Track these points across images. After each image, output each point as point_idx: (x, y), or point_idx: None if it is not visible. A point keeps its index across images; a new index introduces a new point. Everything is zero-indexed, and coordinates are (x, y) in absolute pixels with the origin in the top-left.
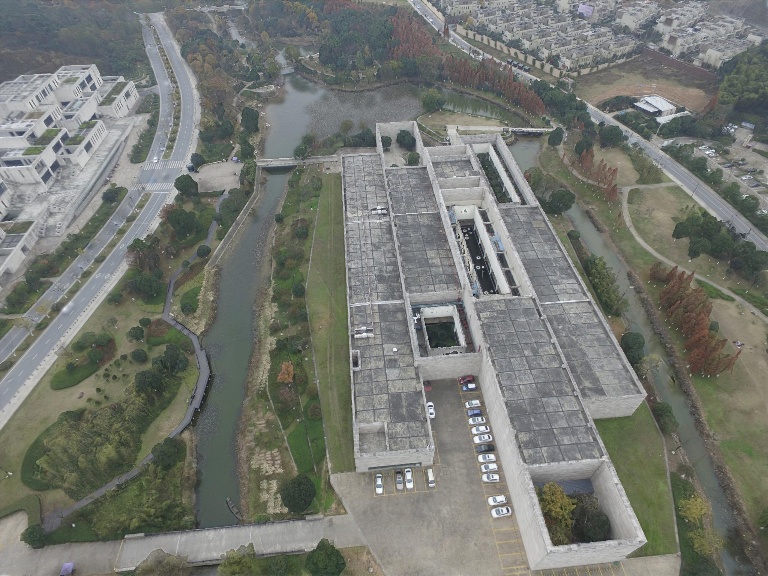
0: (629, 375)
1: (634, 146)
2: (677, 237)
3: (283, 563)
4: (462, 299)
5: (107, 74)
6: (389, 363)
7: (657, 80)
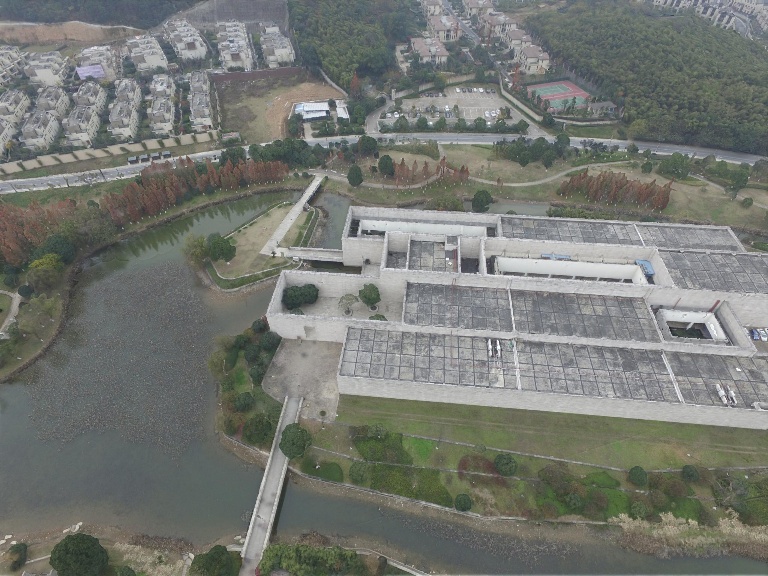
0: None
1: (380, 142)
2: None
3: None
4: None
5: None
6: (759, 378)
7: (270, 94)
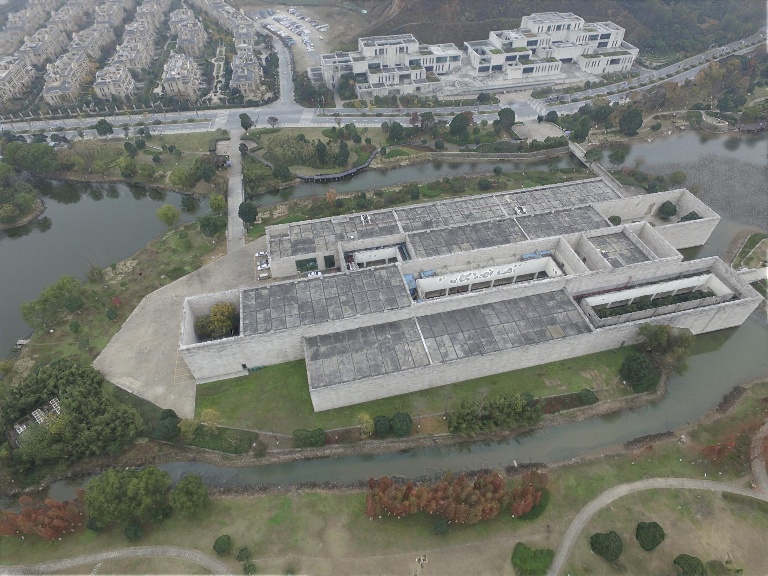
0: None
1: None
2: None
3: (218, 220)
4: None
5: (637, 44)
6: (339, 235)
7: None
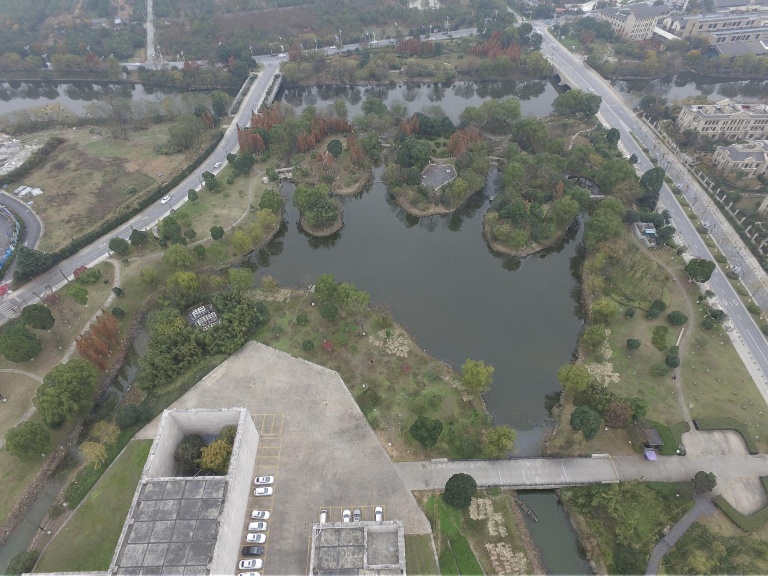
0: None
1: None
2: None
3: (464, 444)
4: None
5: None
6: None
7: None
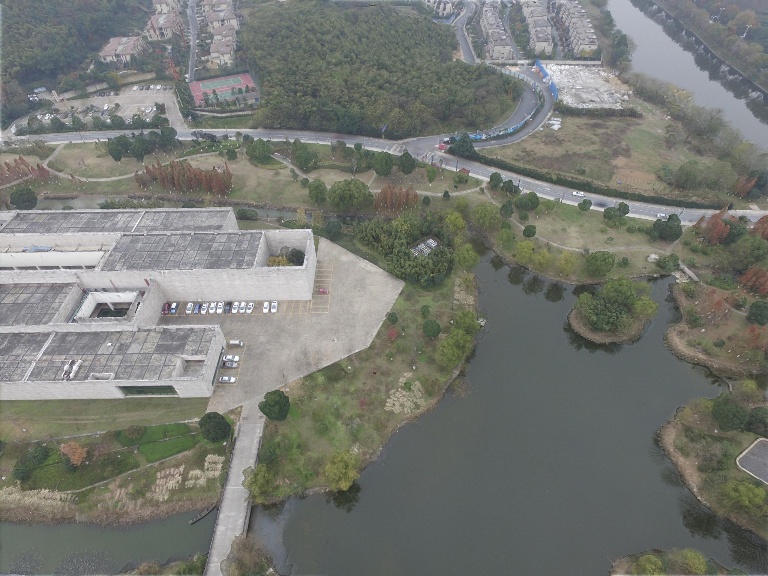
0: (215, 212)
1: None
2: (119, 159)
3: (266, 447)
4: (85, 288)
5: None
6: (121, 350)
7: None
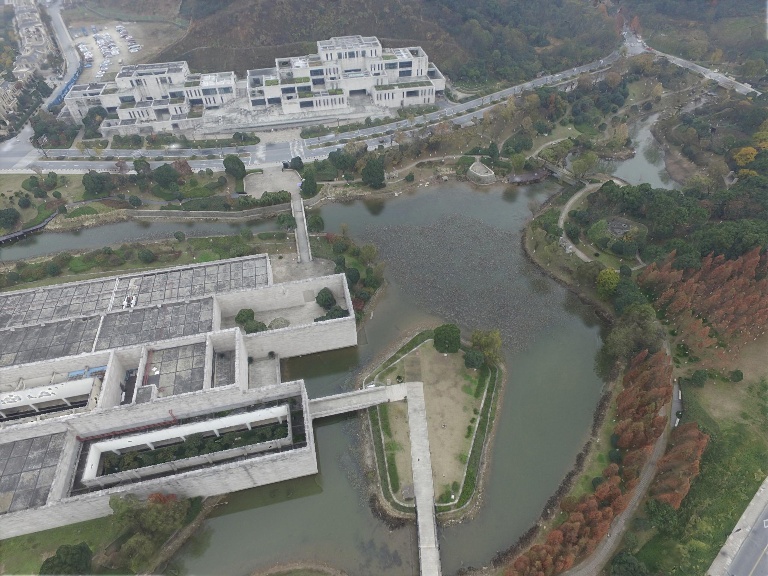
0: None
1: None
2: None
3: None
4: None
5: (451, 72)
6: None
7: None
